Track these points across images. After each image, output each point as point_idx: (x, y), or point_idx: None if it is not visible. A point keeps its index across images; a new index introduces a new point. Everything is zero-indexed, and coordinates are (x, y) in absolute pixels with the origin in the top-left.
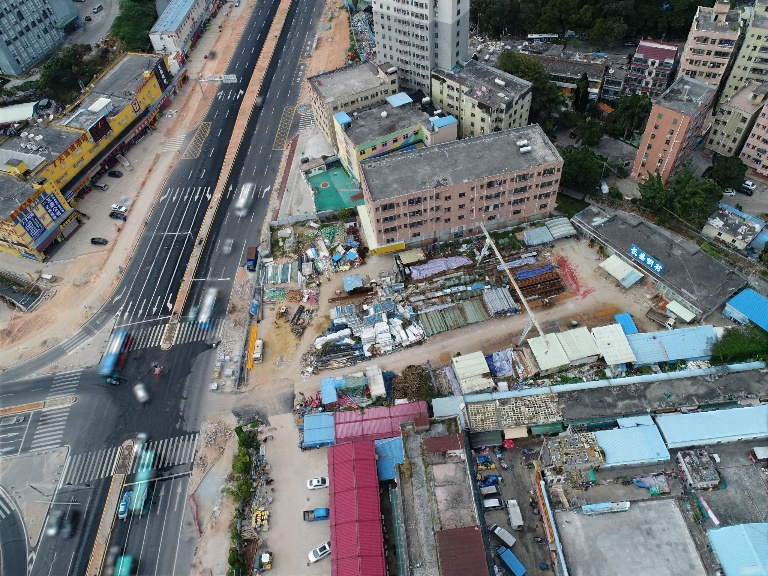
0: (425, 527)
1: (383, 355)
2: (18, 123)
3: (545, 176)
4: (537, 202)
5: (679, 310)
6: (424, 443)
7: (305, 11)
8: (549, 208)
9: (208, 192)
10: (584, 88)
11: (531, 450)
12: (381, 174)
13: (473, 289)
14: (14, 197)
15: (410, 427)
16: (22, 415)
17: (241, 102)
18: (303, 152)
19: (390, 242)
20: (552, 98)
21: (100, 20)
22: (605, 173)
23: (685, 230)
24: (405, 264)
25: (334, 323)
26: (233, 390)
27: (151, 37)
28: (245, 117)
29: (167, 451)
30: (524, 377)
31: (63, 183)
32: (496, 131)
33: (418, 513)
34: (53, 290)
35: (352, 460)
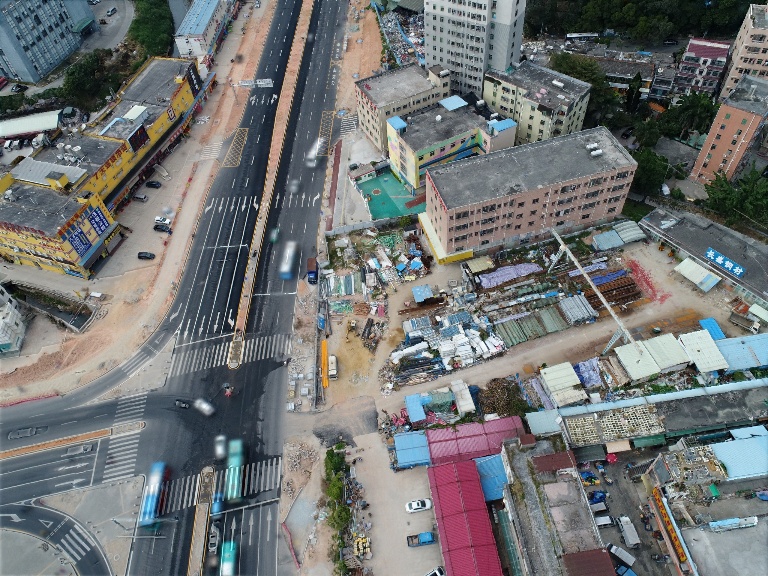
0: (547, 551)
1: (464, 368)
2: (42, 133)
3: (618, 180)
4: (606, 206)
5: (762, 313)
6: (534, 462)
7: (329, 12)
8: (617, 212)
9: (255, 202)
10: (638, 88)
11: (634, 463)
12: (450, 181)
13: (547, 297)
14: (58, 212)
15: (514, 445)
16: (89, 444)
17: (276, 107)
18: (349, 158)
19: (459, 250)
20: (609, 99)
21: (115, 23)
22: (668, 174)
23: (753, 231)
24: (474, 273)
25: (409, 336)
26: (311, 410)
27: (176, 41)
28: (283, 122)
29: (250, 477)
30: (614, 387)
31: (104, 196)
32: (555, 134)
33: (537, 536)
34: (104, 309)
35: (456, 482)
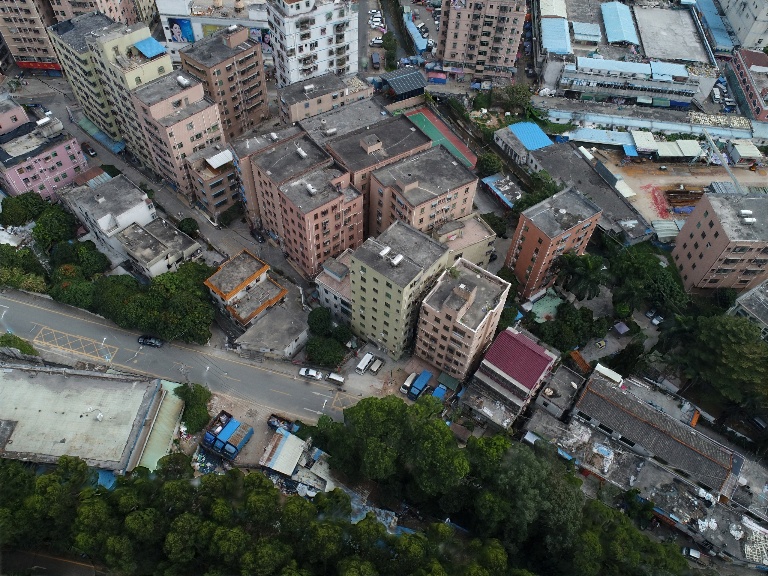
0: None
1: None
2: None
3: None
4: None
5: (585, 154)
6: None
7: None
8: None
9: None
10: None
11: None
12: None
13: None
14: None
15: None
16: None
17: None
18: None
19: None
20: None
21: None
22: None
23: None
24: None
25: None
26: None
27: None
28: None
29: None
30: None
31: None
32: None
33: None
34: None
35: None
